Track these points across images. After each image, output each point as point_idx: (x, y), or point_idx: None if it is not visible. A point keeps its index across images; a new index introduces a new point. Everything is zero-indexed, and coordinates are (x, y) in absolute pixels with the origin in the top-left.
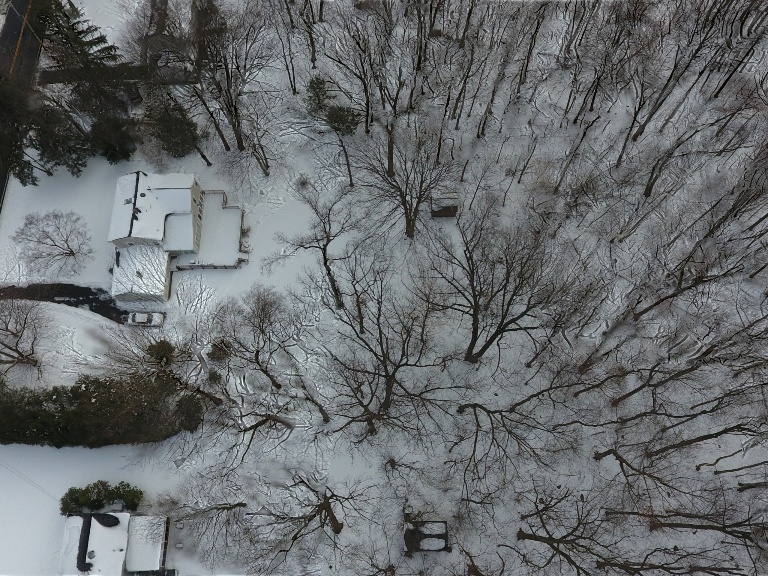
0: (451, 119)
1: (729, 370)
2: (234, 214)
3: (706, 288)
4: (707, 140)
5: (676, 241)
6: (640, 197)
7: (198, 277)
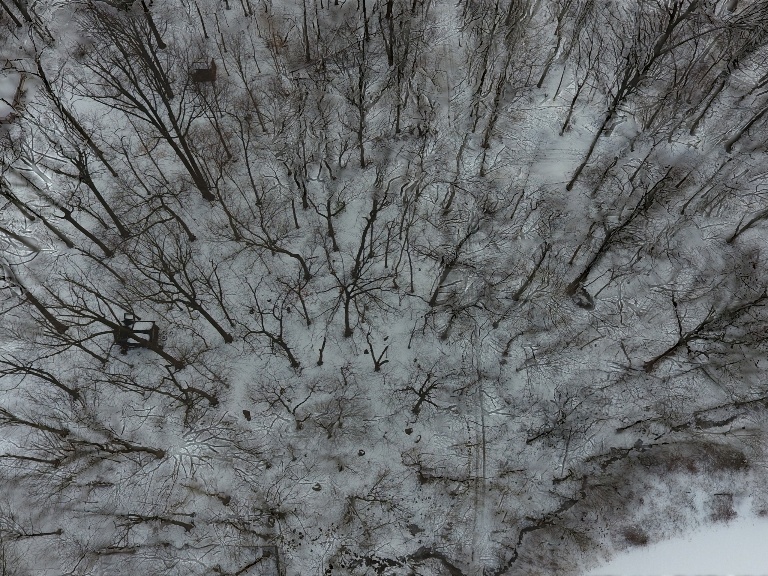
0: (224, 0)
1: (440, 209)
2: (14, 78)
3: (432, 142)
4: (452, 18)
5: (407, 101)
6: (385, 66)
7: None
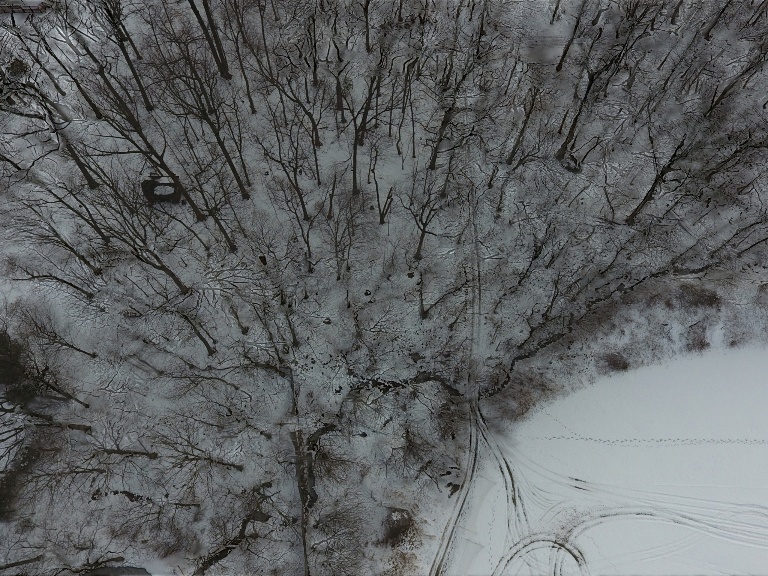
0: None
1: (439, 86)
2: None
3: (432, 29)
4: None
5: None
6: None
7: (9, 18)
